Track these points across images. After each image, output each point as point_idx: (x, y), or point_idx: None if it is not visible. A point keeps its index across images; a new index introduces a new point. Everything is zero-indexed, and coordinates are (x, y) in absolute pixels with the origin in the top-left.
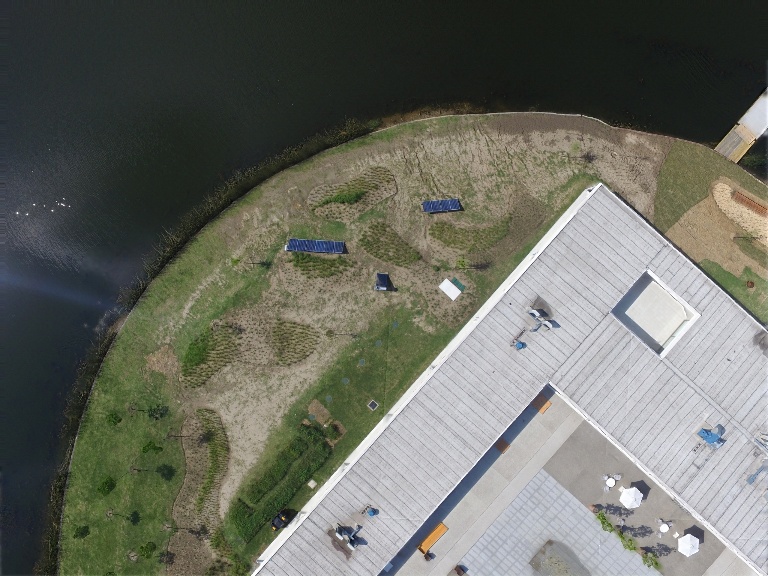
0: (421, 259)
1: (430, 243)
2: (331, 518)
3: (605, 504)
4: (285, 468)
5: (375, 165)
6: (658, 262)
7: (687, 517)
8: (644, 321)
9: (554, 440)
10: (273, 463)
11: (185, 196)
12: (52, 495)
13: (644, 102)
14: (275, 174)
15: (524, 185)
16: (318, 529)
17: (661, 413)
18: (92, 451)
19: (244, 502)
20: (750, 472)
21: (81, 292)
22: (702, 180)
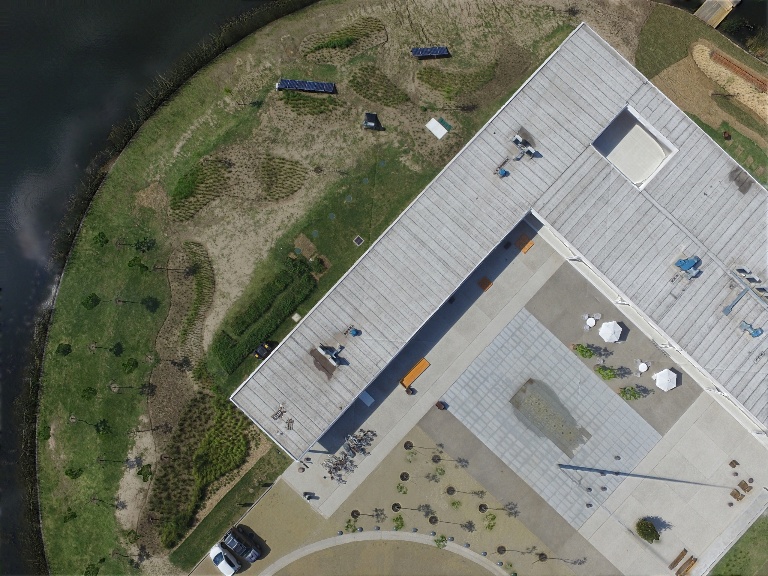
0: (409, 101)
1: (418, 86)
2: (314, 338)
3: (585, 344)
4: (270, 300)
5: (367, 16)
6: (638, 98)
7: (665, 359)
8: (625, 166)
9: (536, 279)
10: (258, 295)
11: (180, 44)
12: (35, 333)
13: None
14: (269, 23)
15: (510, 35)
16: (300, 348)
17: (640, 243)
18: (78, 287)
19: (228, 334)
20: (726, 304)
21: (73, 134)
22: (682, 41)
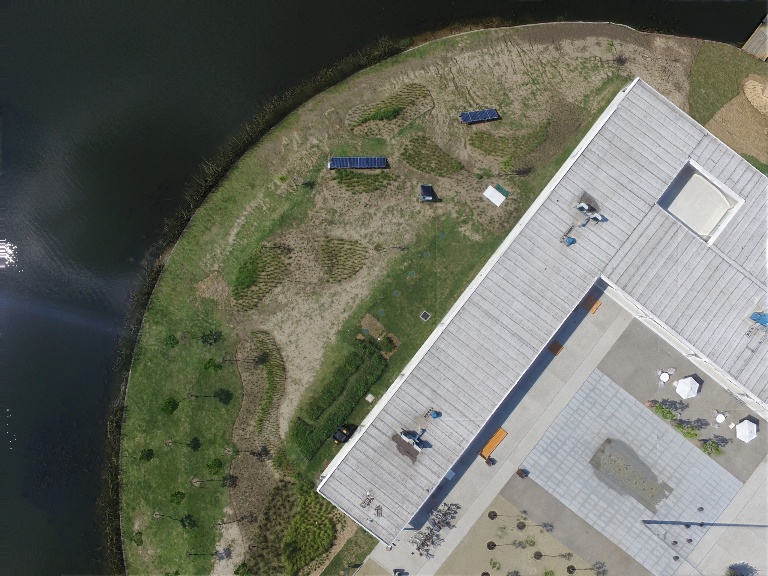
0: (463, 169)
1: (471, 153)
2: (394, 423)
3: (660, 399)
4: (342, 383)
5: (410, 82)
6: (700, 151)
7: (741, 407)
8: (687, 216)
9: (606, 339)
10: (330, 379)
11: (223, 126)
12: (109, 431)
13: (670, 7)
14: (311, 98)
15: (559, 91)
16: (382, 435)
17: (712, 299)
18: (147, 383)
19: (303, 420)
20: None
21: (125, 228)
22: (732, 78)
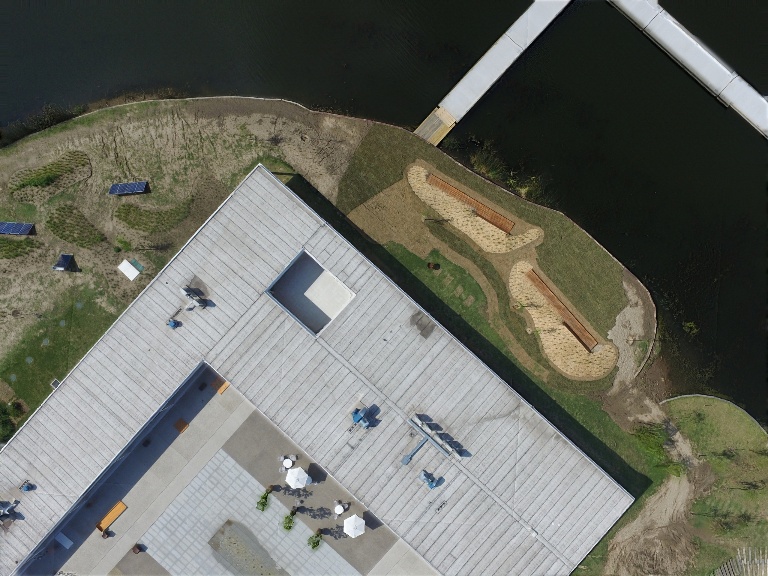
0: (105, 240)
1: (116, 225)
2: None
3: (284, 485)
4: None
5: (74, 149)
6: (315, 242)
7: None
8: (323, 302)
9: (233, 420)
10: None
11: None
12: None
13: (347, 86)
14: None
15: (210, 168)
16: None
17: (316, 392)
18: None
19: None
20: (406, 453)
21: None
22: (398, 163)
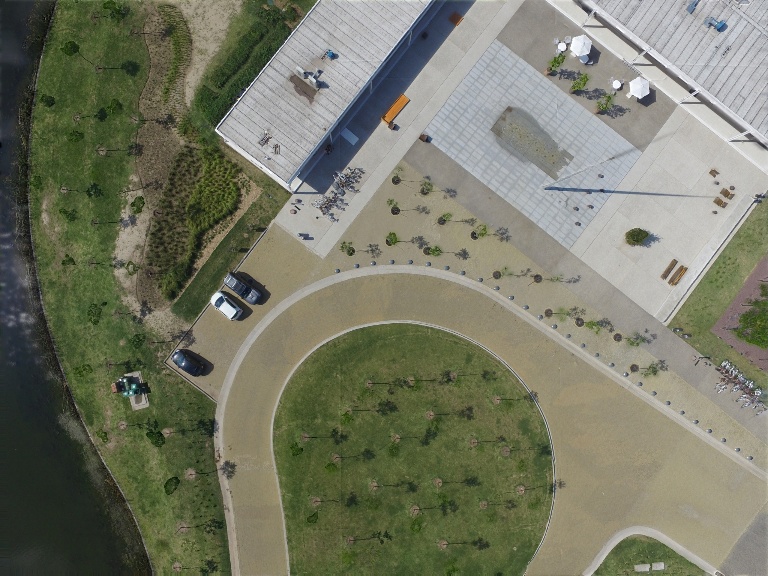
0: None
1: None
2: (292, 65)
3: (559, 69)
4: (247, 50)
5: None
6: None
7: None
8: None
9: (505, 11)
10: (235, 48)
11: None
12: (20, 118)
13: None
14: None
15: None
16: (280, 76)
17: None
18: (57, 65)
19: (209, 88)
20: (689, 3)
21: None
22: None
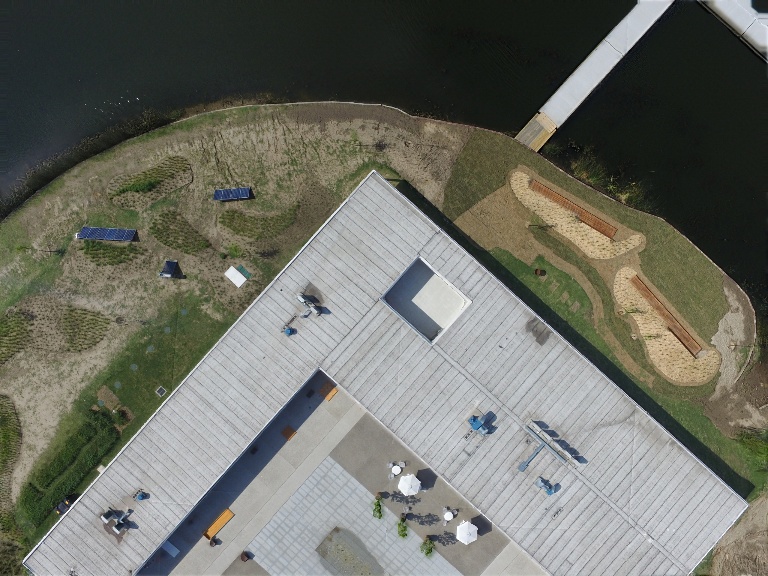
0: (210, 247)
1: (220, 231)
2: (103, 502)
3: (392, 492)
4: (73, 453)
5: (173, 154)
6: (430, 249)
7: None
8: (431, 309)
9: (340, 427)
10: (63, 448)
11: None
12: None
13: (446, 91)
14: (78, 164)
15: (315, 173)
16: (90, 513)
17: (432, 400)
18: None
19: (35, 486)
20: (522, 459)
21: None
22: (500, 169)
